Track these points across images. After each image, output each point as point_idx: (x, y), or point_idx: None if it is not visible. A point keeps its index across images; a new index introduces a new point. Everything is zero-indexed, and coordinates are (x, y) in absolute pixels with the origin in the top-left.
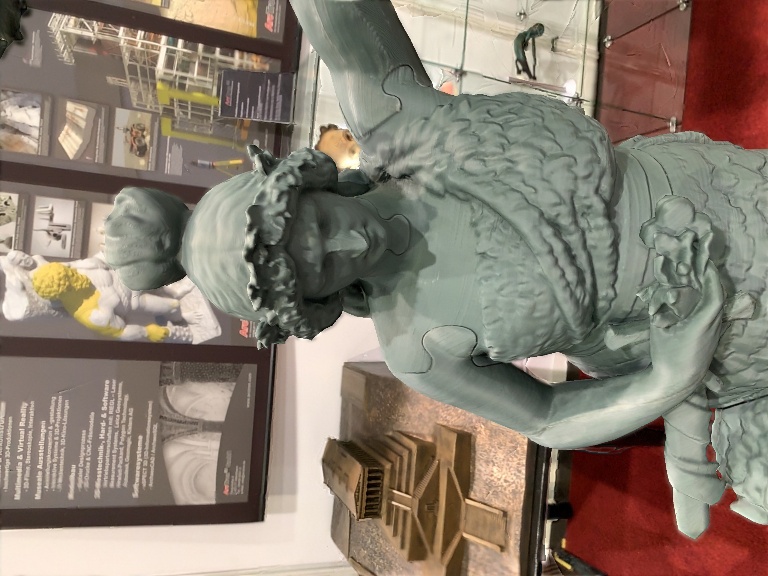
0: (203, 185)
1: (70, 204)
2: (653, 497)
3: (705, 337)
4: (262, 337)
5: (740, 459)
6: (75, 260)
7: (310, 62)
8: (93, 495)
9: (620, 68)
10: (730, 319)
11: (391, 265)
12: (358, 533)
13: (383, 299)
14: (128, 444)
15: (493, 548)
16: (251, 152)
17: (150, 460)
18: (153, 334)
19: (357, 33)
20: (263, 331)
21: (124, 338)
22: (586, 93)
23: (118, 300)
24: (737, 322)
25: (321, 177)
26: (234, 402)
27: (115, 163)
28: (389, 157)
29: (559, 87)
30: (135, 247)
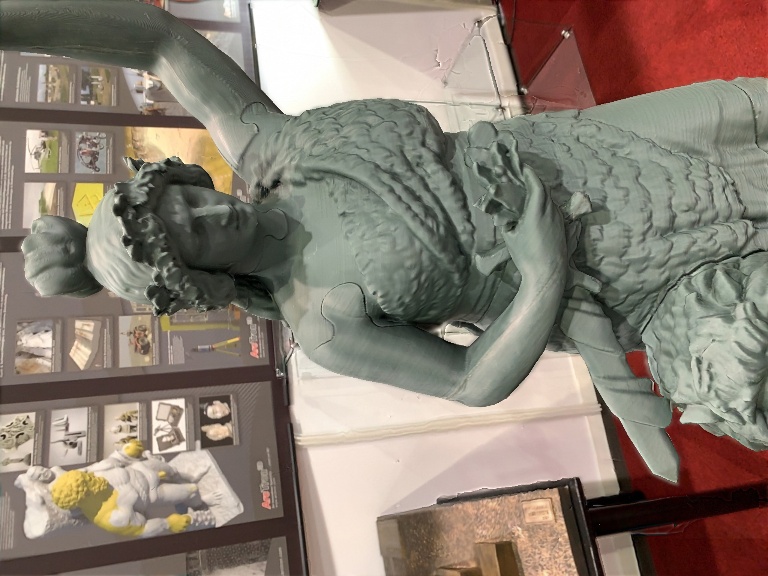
0: (206, 368)
1: (84, 411)
2: None
3: (543, 224)
4: (152, 297)
5: (666, 367)
6: (92, 464)
7: None
8: None
9: None
10: (574, 217)
11: (278, 252)
12: None
13: (283, 289)
14: None
15: None
16: (126, 160)
17: None
18: (175, 524)
19: (211, 84)
20: (151, 290)
21: (146, 535)
22: None
23: (136, 496)
24: (592, 228)
25: (189, 174)
26: None
27: (122, 365)
28: (261, 172)
29: None
30: (44, 254)
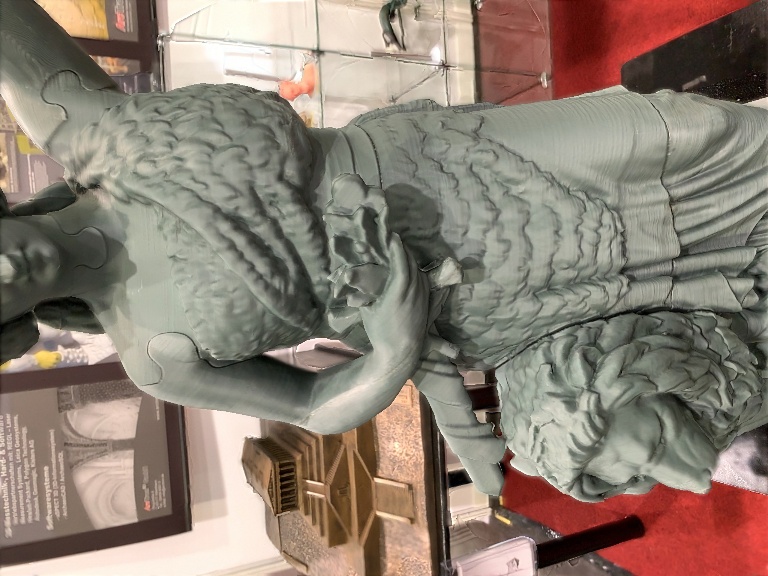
0: None
1: None
2: None
3: (402, 310)
4: None
5: (509, 416)
6: None
7: (172, 59)
8: (4, 535)
9: (495, 29)
10: (442, 287)
11: (94, 280)
12: (286, 527)
13: (105, 314)
14: (34, 477)
15: (404, 521)
16: None
17: (60, 489)
18: (44, 361)
19: None
20: None
21: (12, 370)
22: (465, 58)
23: None
24: (462, 287)
25: None
26: (143, 417)
27: None
28: (73, 168)
29: (424, 56)
30: None
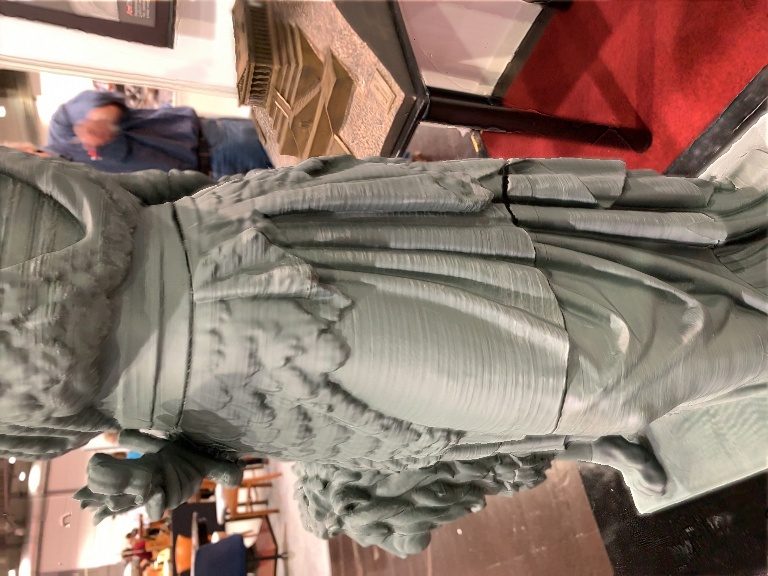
0: None
1: None
2: (559, 145)
3: None
4: None
5: None
6: None
7: None
8: None
9: None
10: None
11: None
12: None
13: None
14: None
15: None
16: None
17: None
18: None
19: None
20: None
21: None
22: None
23: None
24: None
25: None
26: None
27: None
28: None
29: None
30: None
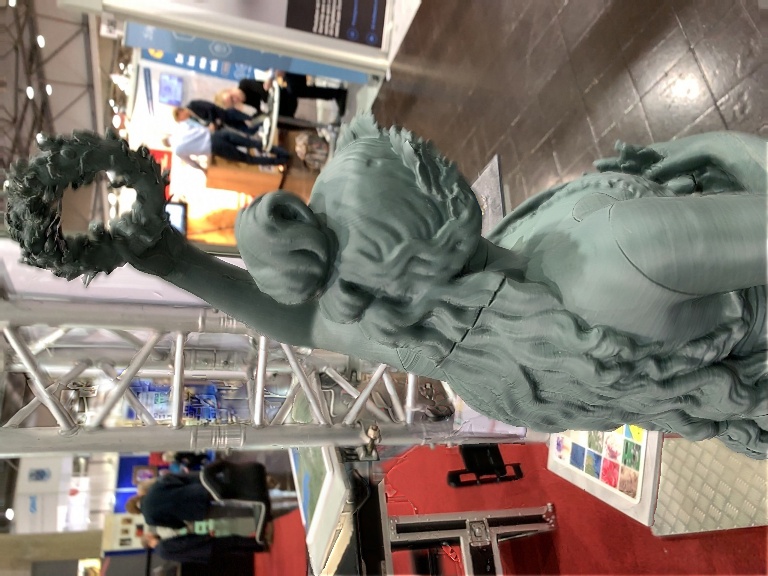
0: None
1: None
2: None
3: None
4: None
5: None
6: None
7: None
8: None
9: None
10: None
11: None
12: None
13: None
14: None
15: None
16: None
17: None
18: None
19: None
20: None
21: None
22: None
23: None
24: None
25: None
26: None
27: None
28: None
29: None
30: None
